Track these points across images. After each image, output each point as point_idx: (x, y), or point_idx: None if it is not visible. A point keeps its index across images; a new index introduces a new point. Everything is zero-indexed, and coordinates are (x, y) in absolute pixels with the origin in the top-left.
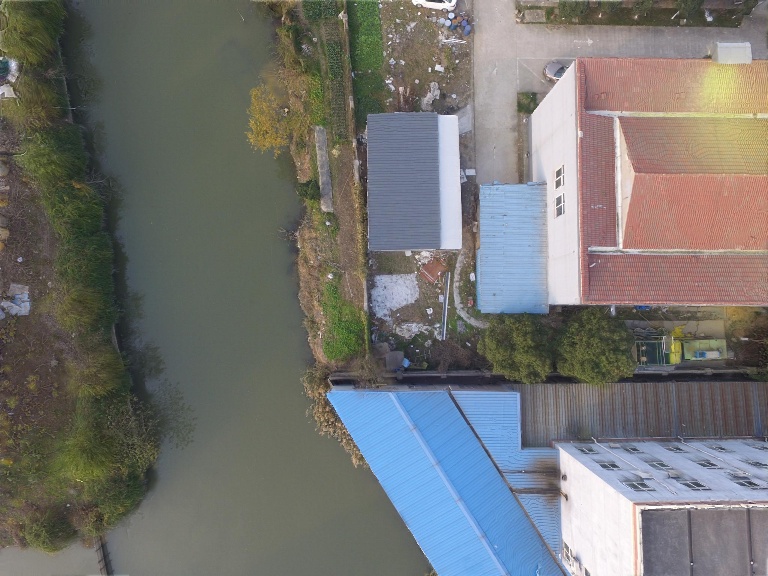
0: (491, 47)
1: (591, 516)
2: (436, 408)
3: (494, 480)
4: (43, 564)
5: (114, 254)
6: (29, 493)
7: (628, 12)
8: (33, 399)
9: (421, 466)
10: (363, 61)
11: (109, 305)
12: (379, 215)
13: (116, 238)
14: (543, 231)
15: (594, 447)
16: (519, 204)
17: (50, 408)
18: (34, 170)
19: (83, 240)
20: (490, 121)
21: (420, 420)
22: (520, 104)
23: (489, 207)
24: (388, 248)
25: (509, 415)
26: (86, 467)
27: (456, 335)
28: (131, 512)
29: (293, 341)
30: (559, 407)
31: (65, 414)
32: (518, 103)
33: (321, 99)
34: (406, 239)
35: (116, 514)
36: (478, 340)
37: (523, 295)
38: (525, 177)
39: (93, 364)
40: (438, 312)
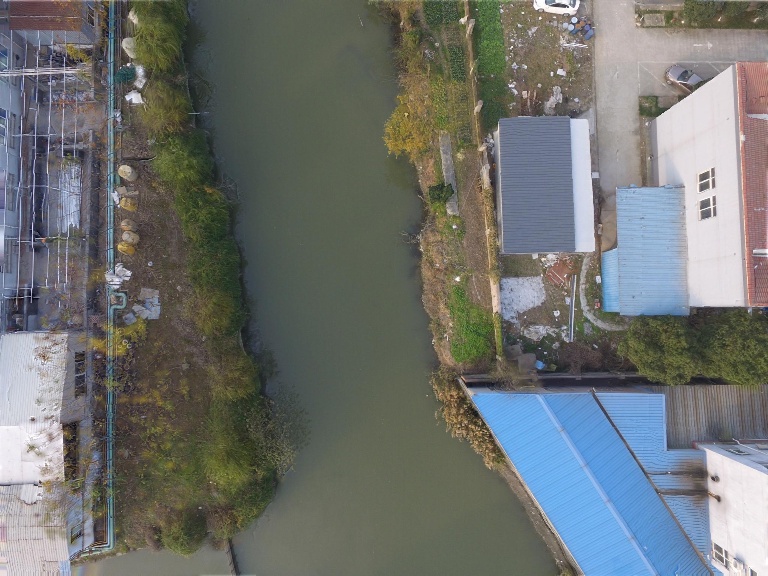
0: (612, 51)
1: (763, 517)
2: (582, 410)
3: (640, 481)
4: (176, 566)
5: (240, 258)
6: (163, 496)
7: (747, 16)
8: (165, 402)
9: (569, 468)
10: (486, 66)
11: (238, 309)
12: (513, 218)
13: (237, 242)
14: (682, 234)
15: (741, 448)
16: (657, 207)
17: (182, 411)
18: (164, 175)
19: (215, 244)
20: (612, 124)
21: (567, 422)
22: (642, 107)
23: (626, 210)
24: (523, 251)
25: (655, 417)
26: (221, 470)
27: (583, 337)
28: (261, 514)
29: (417, 344)
30: (699, 408)
31: (197, 417)
32: (640, 106)
33: (445, 103)
34: (541, 242)
35: (250, 516)
36: (605, 342)
37: (663, 297)
38: (648, 180)
39: (235, 367)
40: (565, 314)
